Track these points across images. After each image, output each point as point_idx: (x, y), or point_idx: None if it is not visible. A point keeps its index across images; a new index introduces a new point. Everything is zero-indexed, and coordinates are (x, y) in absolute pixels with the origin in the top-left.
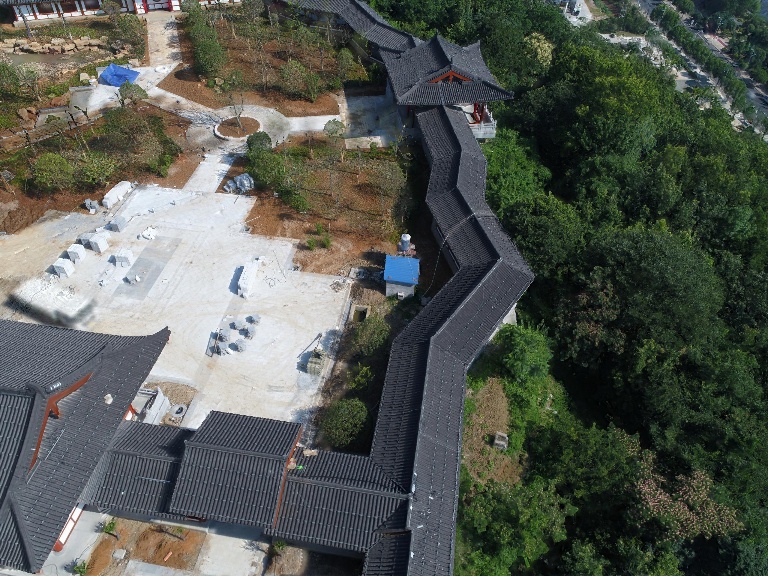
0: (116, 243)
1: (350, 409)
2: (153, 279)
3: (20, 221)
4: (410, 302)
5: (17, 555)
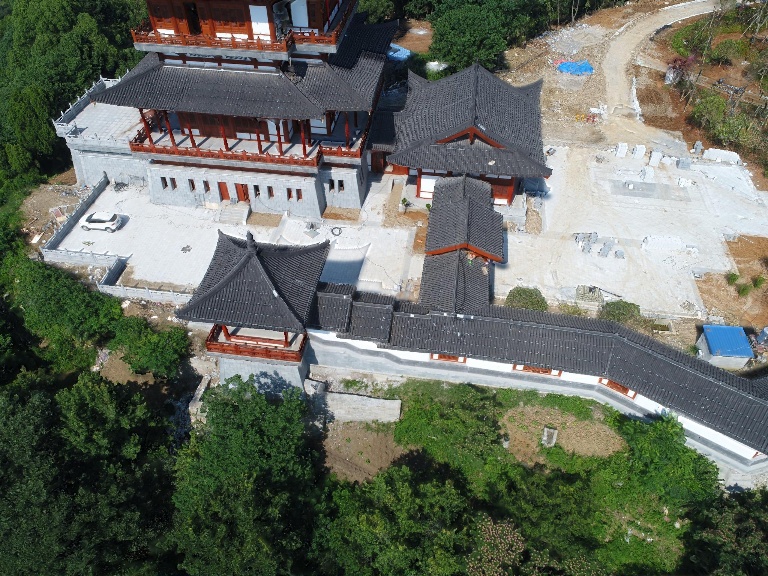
0: (664, 169)
1: (532, 295)
2: (636, 195)
3: (659, 123)
4: None
5: None
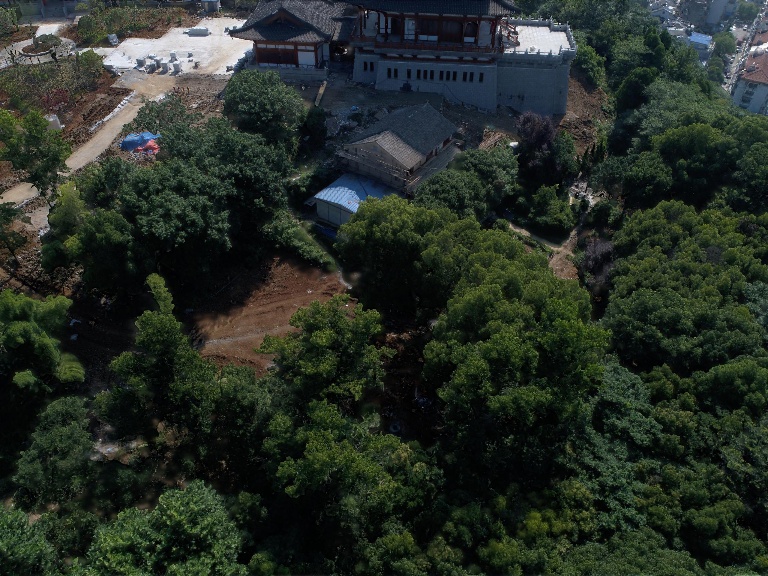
0: None
1: None
2: None
3: None
4: (223, 8)
5: (343, 4)
